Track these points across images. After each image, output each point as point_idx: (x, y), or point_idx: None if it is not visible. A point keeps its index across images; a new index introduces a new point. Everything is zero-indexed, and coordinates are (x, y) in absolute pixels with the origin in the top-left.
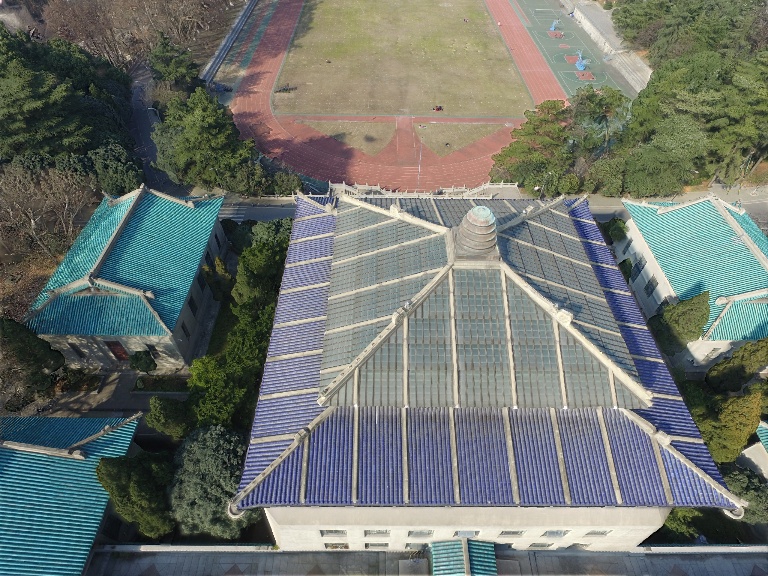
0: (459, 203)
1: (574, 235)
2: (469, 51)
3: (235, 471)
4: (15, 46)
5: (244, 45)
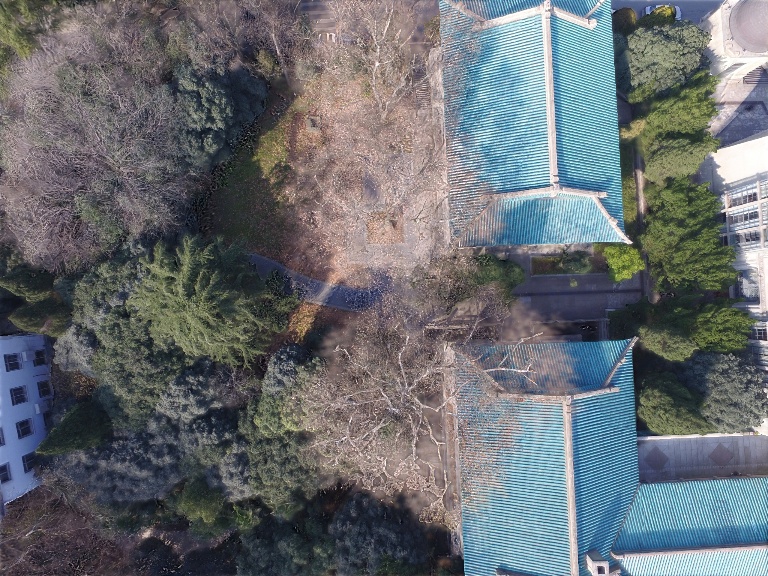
0: None
1: None
2: None
3: (762, 399)
4: None
5: None
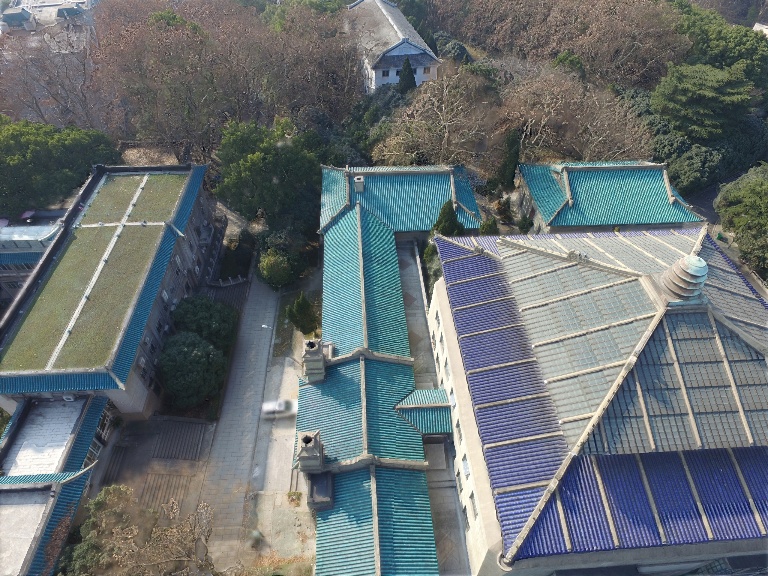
0: (767, 319)
1: None
2: None
3: None
4: (767, 60)
5: None
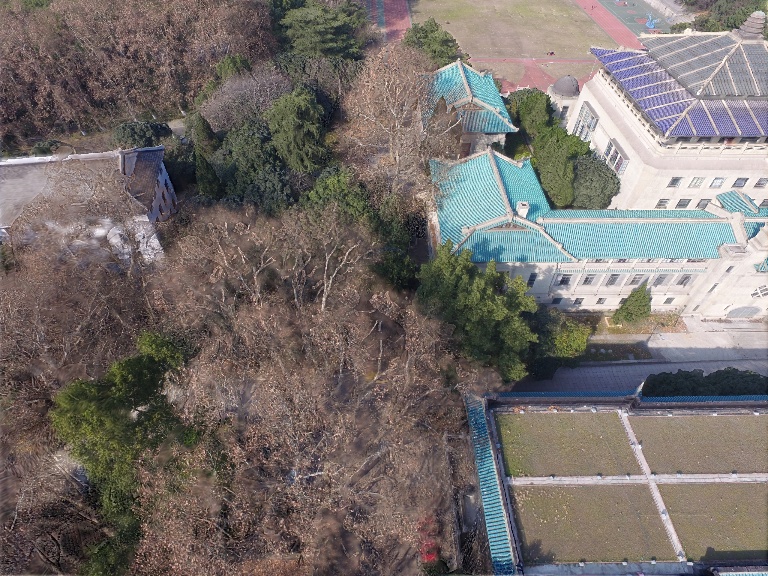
0: None
1: None
2: (556, 15)
3: None
4: None
5: (373, 11)
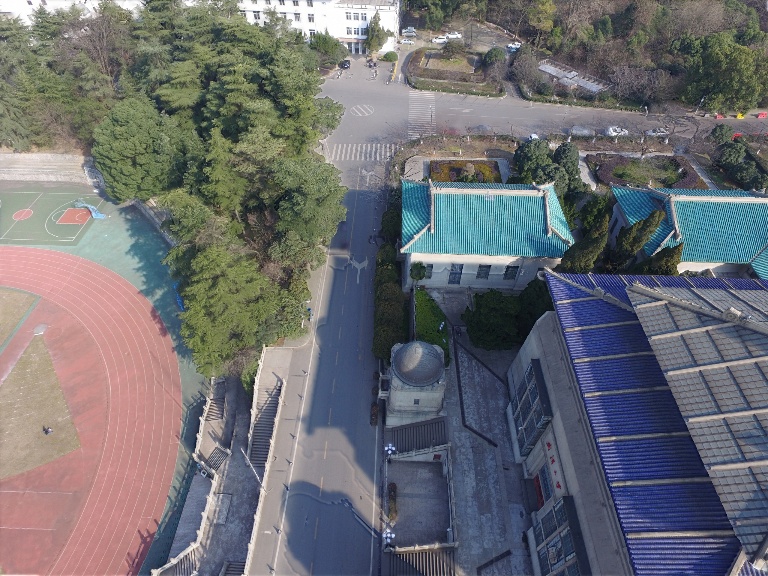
0: (690, 387)
1: (685, 290)
2: None
3: None
4: None
5: None
